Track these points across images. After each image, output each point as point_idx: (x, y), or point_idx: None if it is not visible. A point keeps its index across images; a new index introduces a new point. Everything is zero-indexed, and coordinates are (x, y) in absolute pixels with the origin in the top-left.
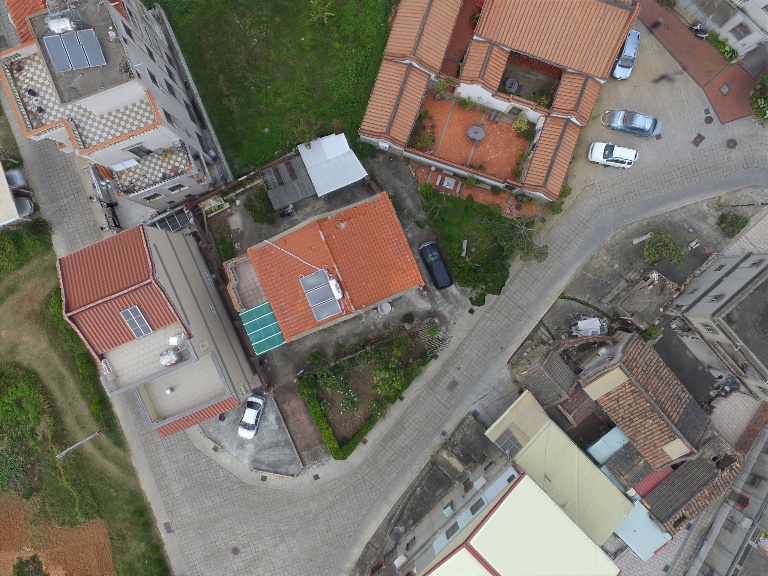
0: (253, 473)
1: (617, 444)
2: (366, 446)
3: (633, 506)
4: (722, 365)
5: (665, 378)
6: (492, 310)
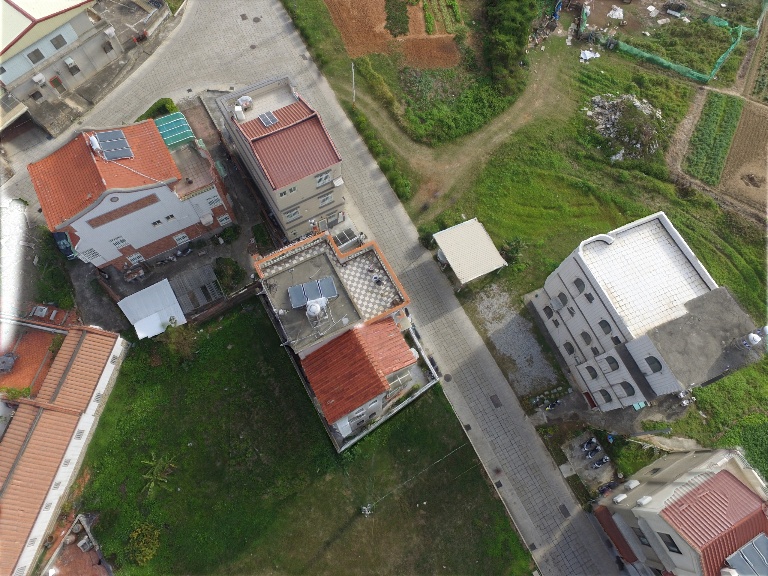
0: None
1: None
2: None
3: None
4: None
5: None
6: None
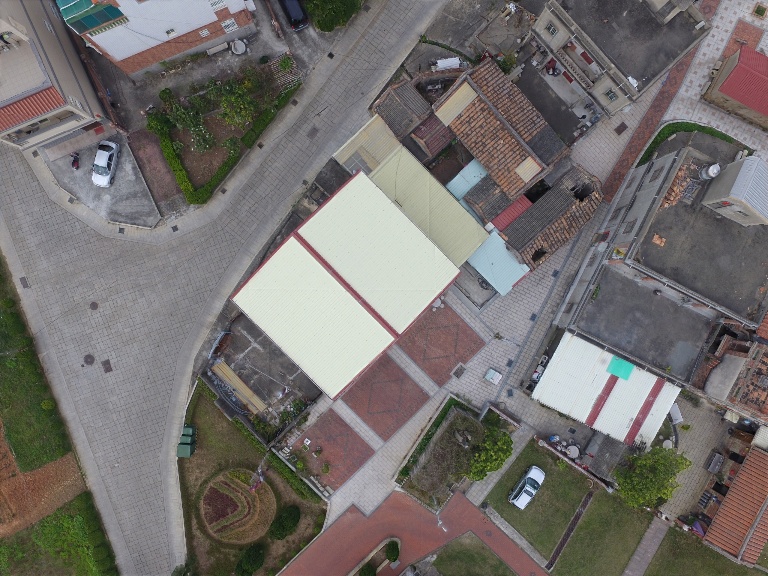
0: (110, 225)
1: (475, 178)
2: (225, 196)
3: (488, 235)
4: (584, 102)
5: (519, 102)
6: (352, 54)
